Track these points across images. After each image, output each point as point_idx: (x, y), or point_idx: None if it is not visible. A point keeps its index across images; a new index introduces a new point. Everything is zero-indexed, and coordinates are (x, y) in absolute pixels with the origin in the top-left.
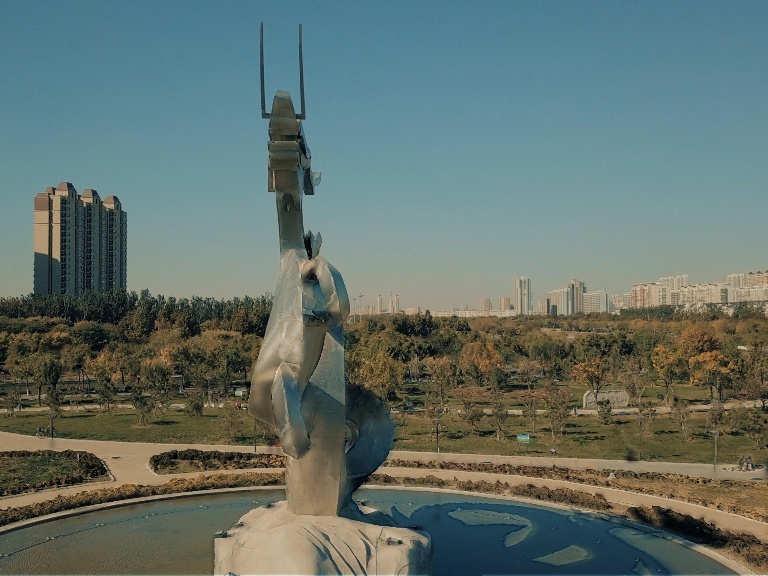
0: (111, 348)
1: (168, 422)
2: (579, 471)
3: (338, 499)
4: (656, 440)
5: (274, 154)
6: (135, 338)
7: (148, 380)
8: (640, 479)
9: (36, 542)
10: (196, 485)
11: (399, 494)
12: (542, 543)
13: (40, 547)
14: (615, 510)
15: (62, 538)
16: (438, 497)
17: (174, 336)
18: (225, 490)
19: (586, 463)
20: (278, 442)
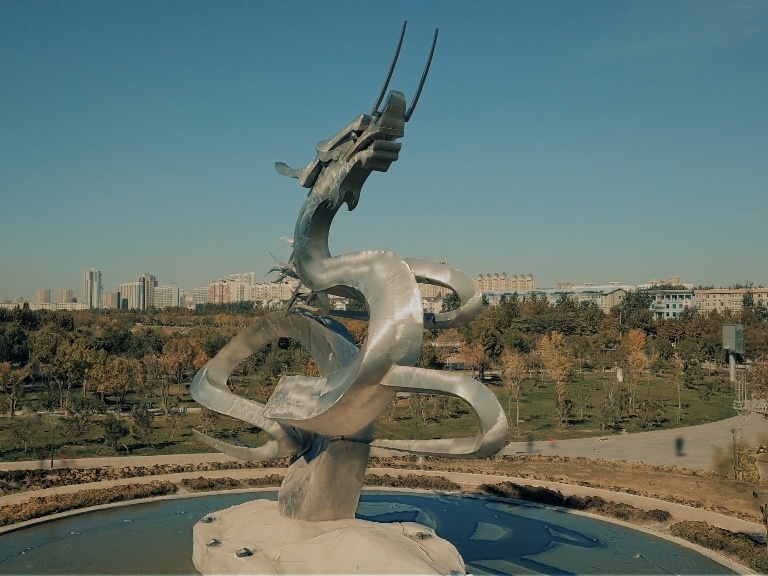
0: None
1: None
2: (388, 459)
3: None
4: (404, 427)
5: (377, 153)
6: None
7: None
8: (441, 461)
9: None
10: (39, 510)
11: (261, 496)
12: (452, 524)
13: None
14: (465, 489)
15: None
16: None
17: None
18: (74, 512)
19: (378, 451)
20: (47, 455)
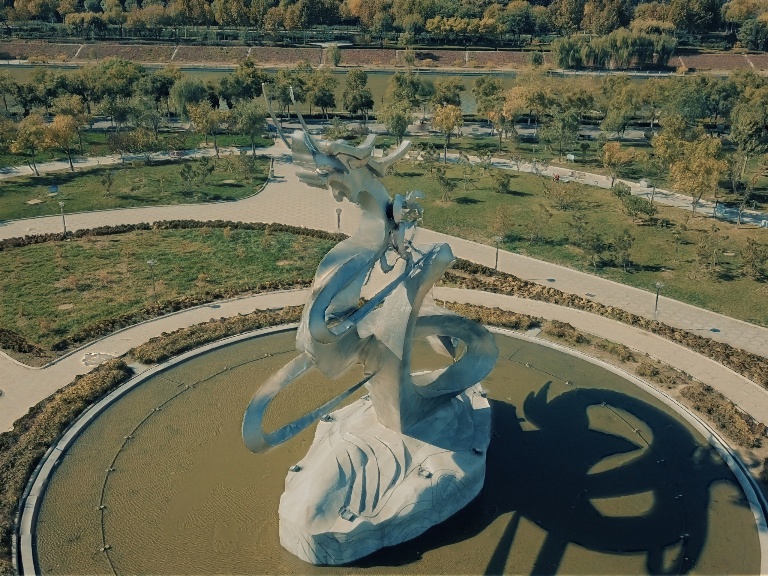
0: (478, 83)
1: (469, 200)
2: None
3: (402, 422)
4: None
5: (303, 179)
6: (504, 72)
7: (461, 155)
8: None
9: (257, 357)
10: None
11: (574, 363)
12: (627, 478)
13: (256, 363)
14: (759, 452)
15: (277, 355)
16: (605, 378)
17: (540, 73)
18: None
19: None
20: (540, 251)
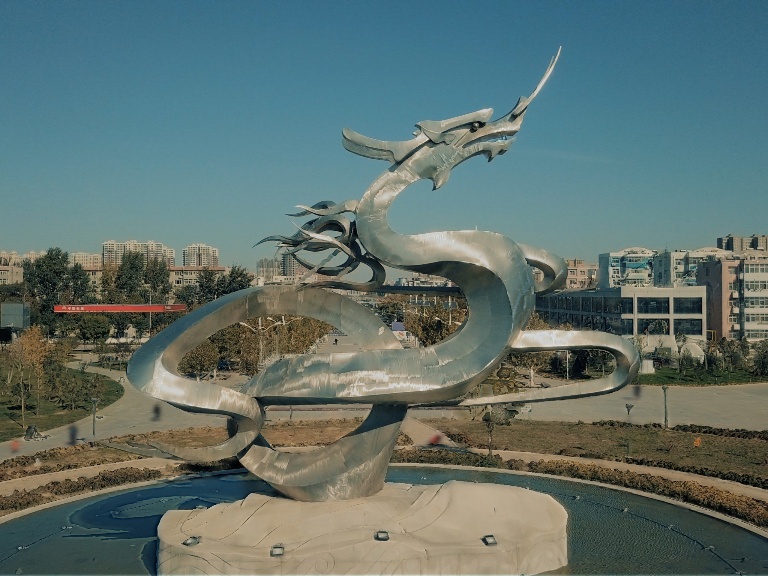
0: None
1: None
2: None
3: None
4: None
5: None
6: None
7: None
8: (48, 460)
9: None
10: None
11: (2, 533)
12: None
13: None
14: (164, 474)
15: None
16: (39, 519)
17: None
18: None
19: None
20: None
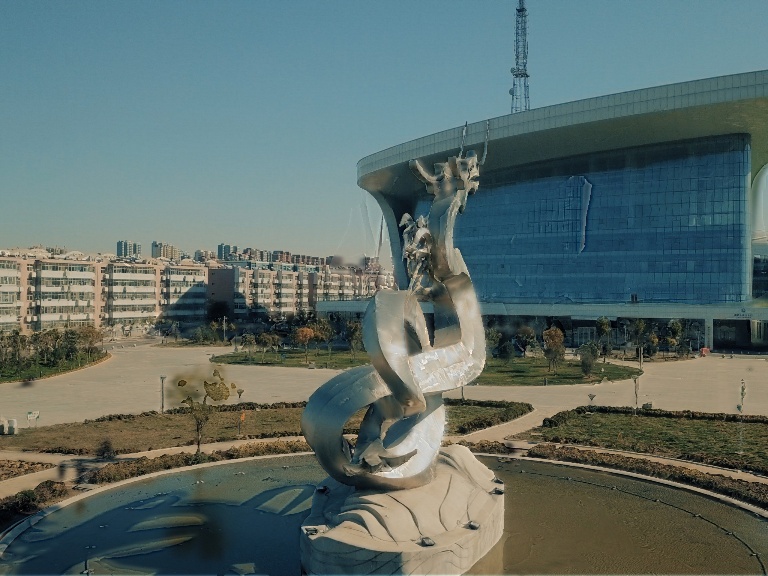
0: None
1: None
2: None
3: None
4: None
5: None
6: None
7: None
8: None
9: None
10: None
11: None
12: None
13: None
14: None
15: None
16: None
17: None
18: None
19: None
20: None
